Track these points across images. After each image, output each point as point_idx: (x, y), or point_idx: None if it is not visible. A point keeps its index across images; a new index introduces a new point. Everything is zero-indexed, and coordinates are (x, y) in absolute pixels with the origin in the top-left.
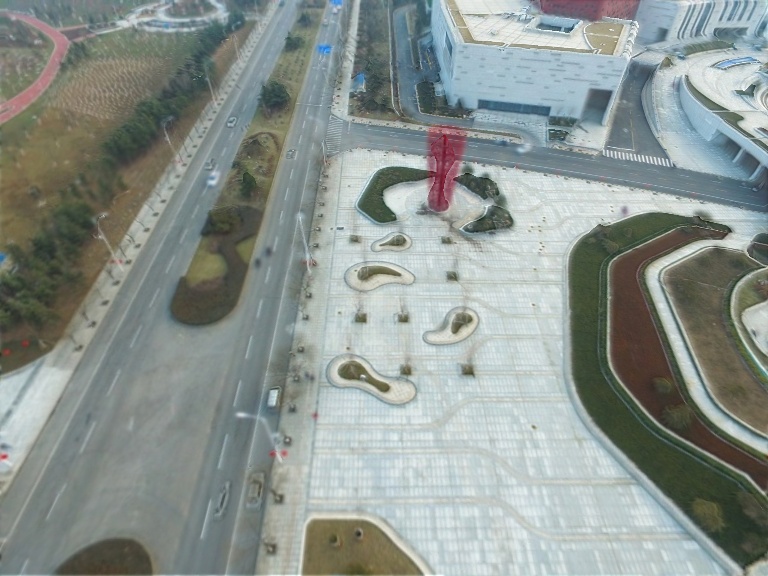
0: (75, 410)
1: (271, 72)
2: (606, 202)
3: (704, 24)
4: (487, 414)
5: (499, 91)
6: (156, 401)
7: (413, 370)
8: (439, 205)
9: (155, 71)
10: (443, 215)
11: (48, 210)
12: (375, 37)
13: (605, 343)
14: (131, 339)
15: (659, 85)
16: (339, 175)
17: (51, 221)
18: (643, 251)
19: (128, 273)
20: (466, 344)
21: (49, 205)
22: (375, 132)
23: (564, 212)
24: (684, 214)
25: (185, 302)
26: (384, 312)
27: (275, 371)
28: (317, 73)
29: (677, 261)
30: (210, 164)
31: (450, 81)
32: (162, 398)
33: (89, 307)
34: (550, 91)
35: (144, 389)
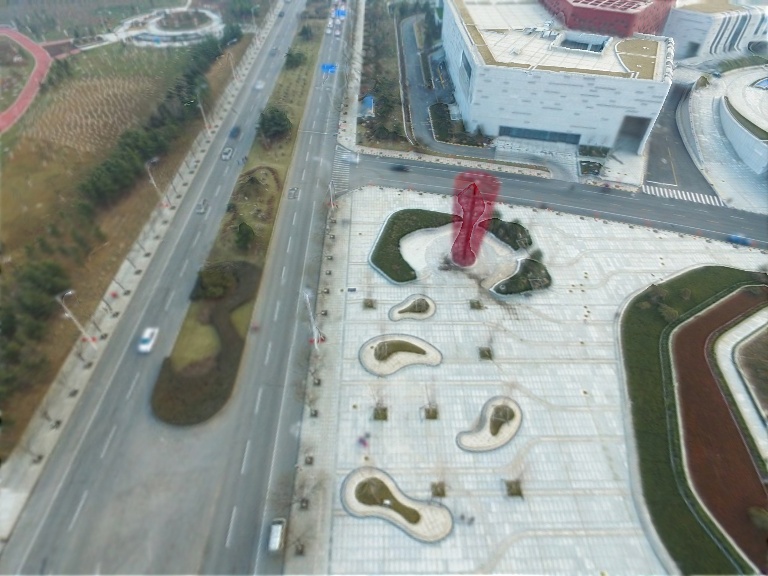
0: (27, 554)
1: (270, 93)
2: (654, 252)
3: (738, 38)
4: (543, 555)
5: (523, 117)
6: (129, 539)
7: (447, 490)
8: (464, 258)
9: (143, 93)
10: (470, 271)
11: (11, 272)
12: (382, 52)
13: (679, 450)
14: (102, 446)
15: (696, 108)
16: (348, 220)
17: (12, 288)
18: (707, 319)
19: (103, 352)
20: (509, 450)
21: (13, 265)
22: (387, 165)
23: (608, 266)
24: (745, 267)
25: (169, 394)
26: (408, 405)
27: (278, 492)
28: (321, 94)
29: (751, 334)
30: (202, 206)
31: (468, 106)
32: (137, 535)
33: (53, 403)
34: (581, 118)
35: (115, 521)
